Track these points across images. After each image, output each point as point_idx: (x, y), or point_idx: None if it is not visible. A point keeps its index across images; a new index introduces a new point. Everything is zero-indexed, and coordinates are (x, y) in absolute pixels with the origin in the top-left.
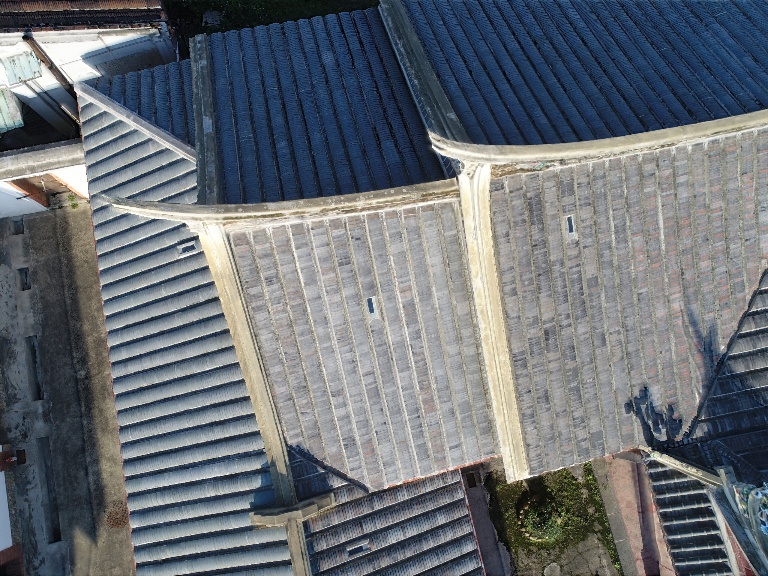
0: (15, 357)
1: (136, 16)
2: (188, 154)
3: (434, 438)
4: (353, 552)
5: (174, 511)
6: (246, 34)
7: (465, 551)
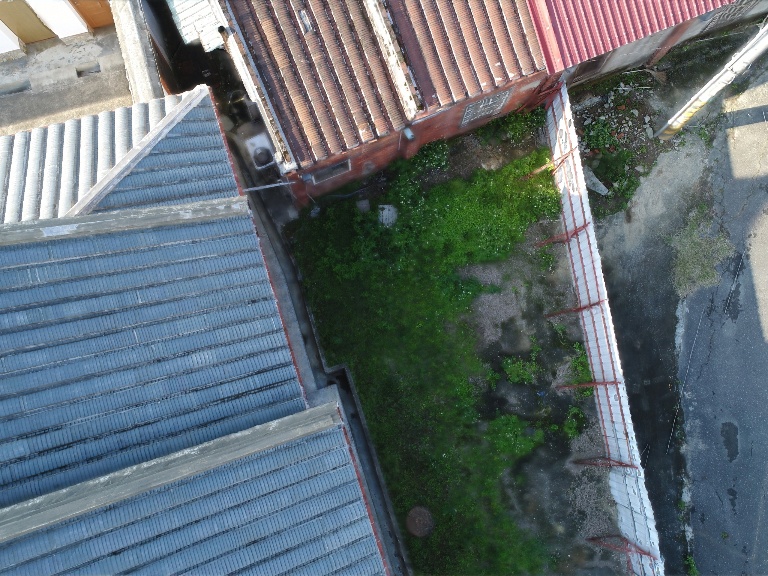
0: (8, 74)
1: (295, 135)
2: (68, 212)
3: None
4: None
5: None
6: (249, 258)
7: None
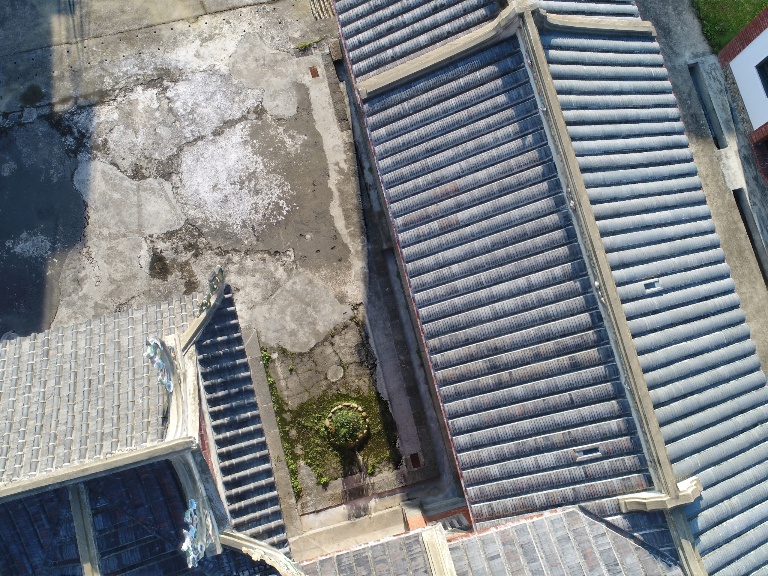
0: None
1: None
2: None
3: (519, 569)
4: (594, 450)
5: (761, 476)
6: None
7: (467, 437)
